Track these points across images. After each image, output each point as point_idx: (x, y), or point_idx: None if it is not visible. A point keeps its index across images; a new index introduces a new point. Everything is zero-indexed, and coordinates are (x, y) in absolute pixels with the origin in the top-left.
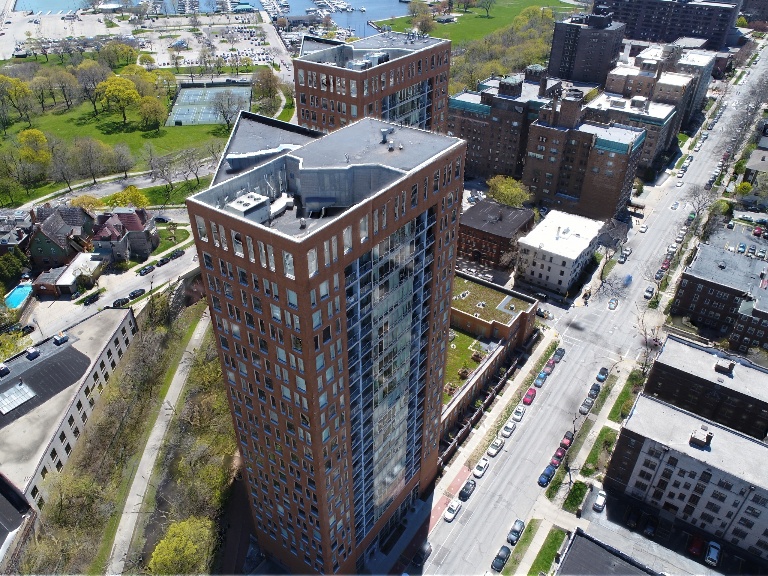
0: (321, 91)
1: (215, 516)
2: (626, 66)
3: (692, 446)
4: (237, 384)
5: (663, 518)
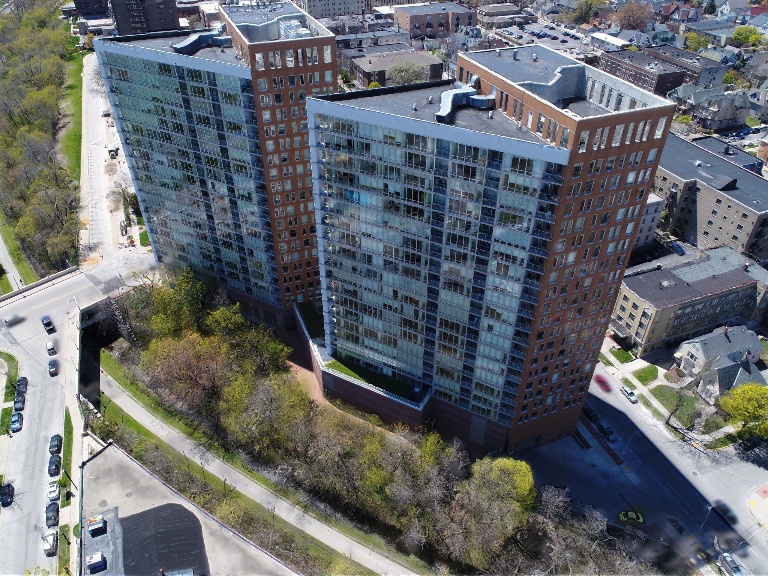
0: (288, 69)
1: (444, 478)
2: (216, 22)
3: None
4: (559, 280)
5: None
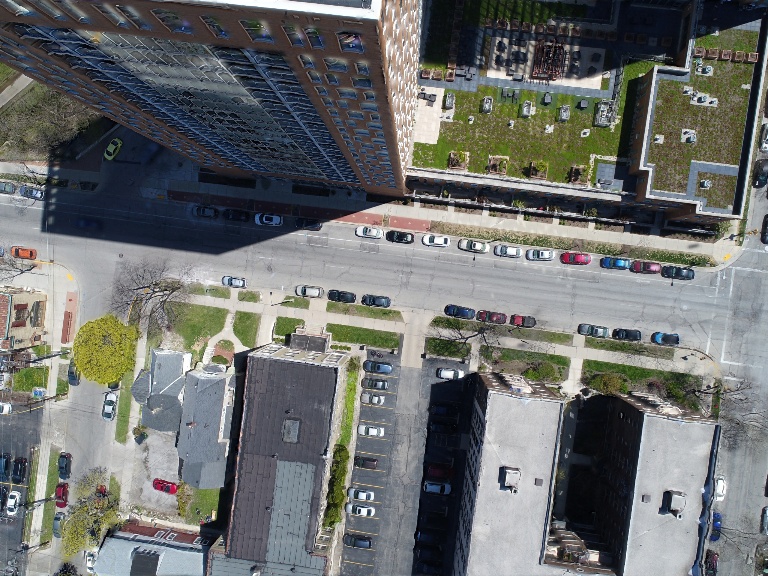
0: None
1: None
2: None
3: (500, 470)
4: None
5: (460, 438)
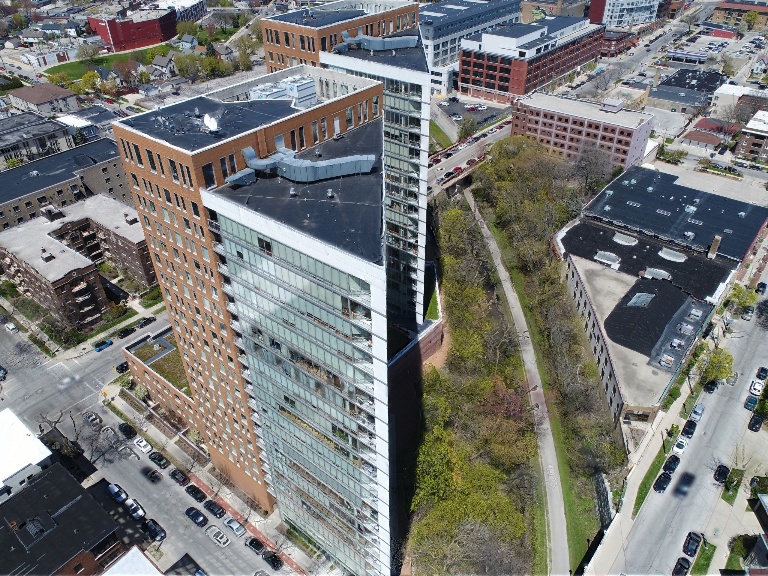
0: None
1: None
2: None
3: (138, 221)
4: None
5: None
